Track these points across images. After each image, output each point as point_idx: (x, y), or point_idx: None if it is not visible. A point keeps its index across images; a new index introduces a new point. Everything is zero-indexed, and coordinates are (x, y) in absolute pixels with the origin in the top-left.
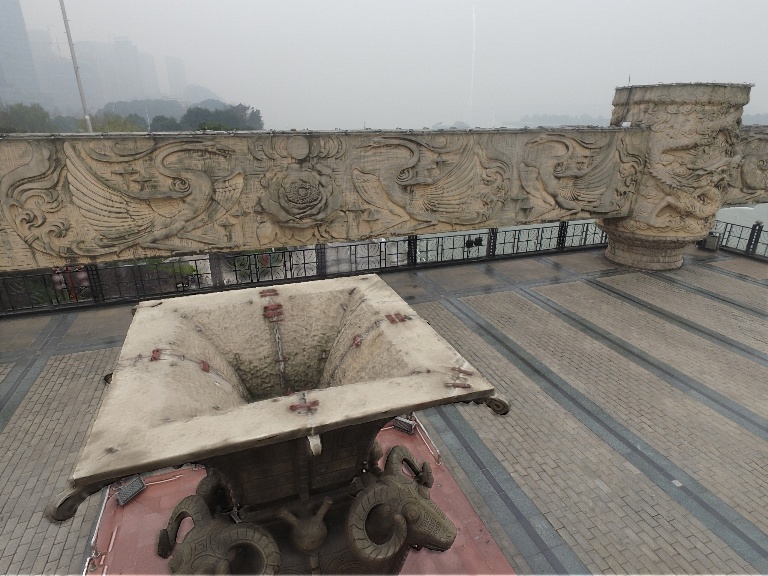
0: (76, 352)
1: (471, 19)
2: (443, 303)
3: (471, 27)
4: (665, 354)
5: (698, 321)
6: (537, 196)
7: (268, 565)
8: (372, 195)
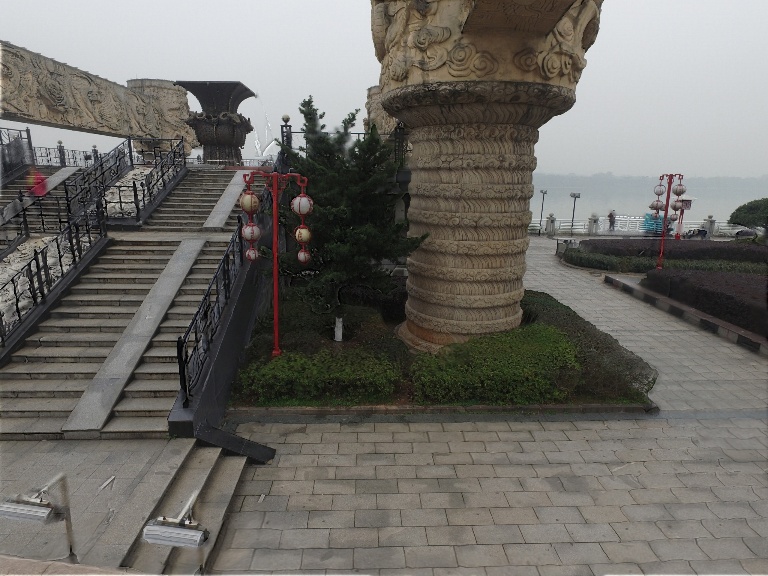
0: None
1: None
2: None
3: None
4: None
5: None
6: (133, 122)
7: None
8: (79, 102)
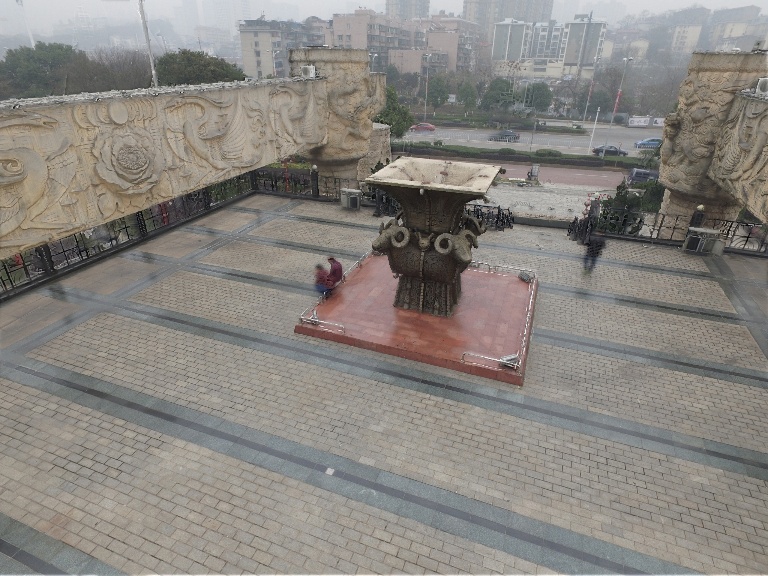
0: (723, 289)
1: None
2: None
3: None
4: None
5: None
6: None
7: None
8: None
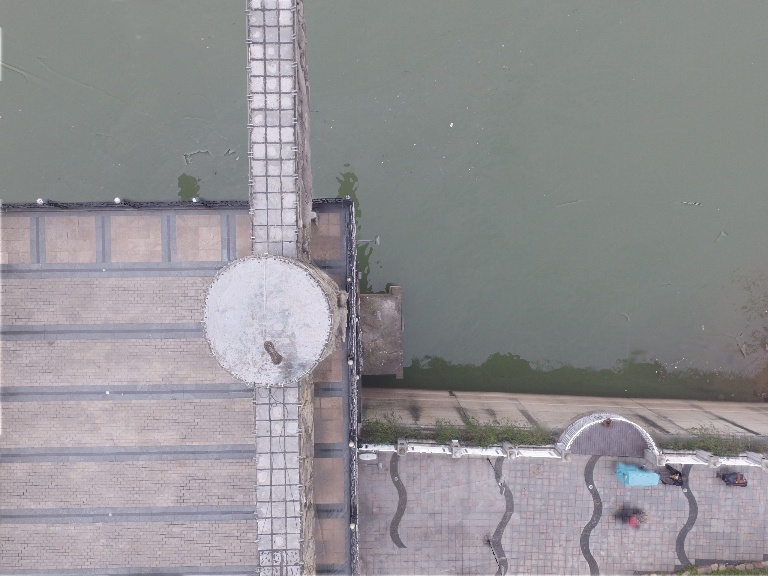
0: None
1: None
2: None
3: None
4: (39, 439)
5: (13, 383)
6: None
7: None
8: None
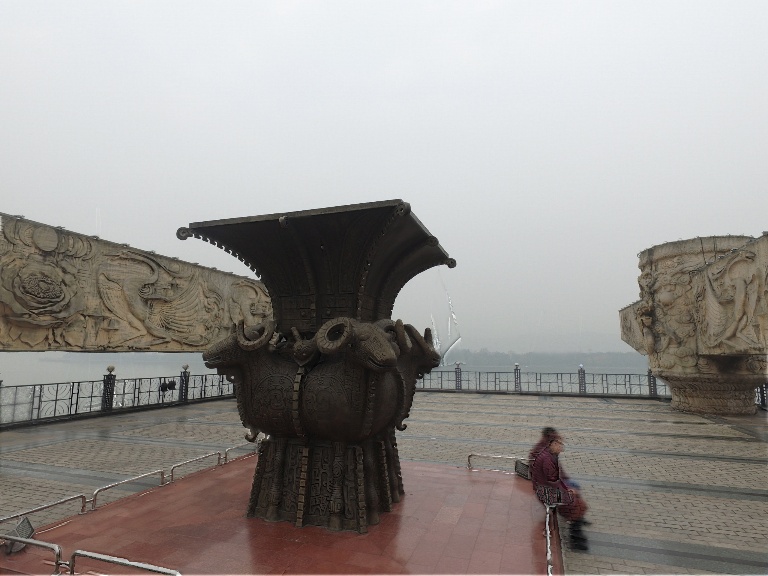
0: None
1: (95, 218)
2: (178, 422)
3: (95, 224)
4: None
5: None
6: None
7: (406, 336)
8: (114, 304)
